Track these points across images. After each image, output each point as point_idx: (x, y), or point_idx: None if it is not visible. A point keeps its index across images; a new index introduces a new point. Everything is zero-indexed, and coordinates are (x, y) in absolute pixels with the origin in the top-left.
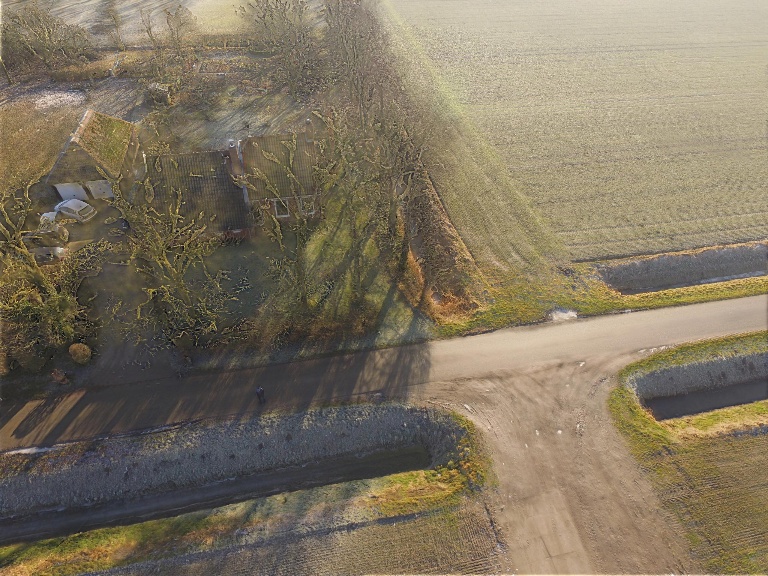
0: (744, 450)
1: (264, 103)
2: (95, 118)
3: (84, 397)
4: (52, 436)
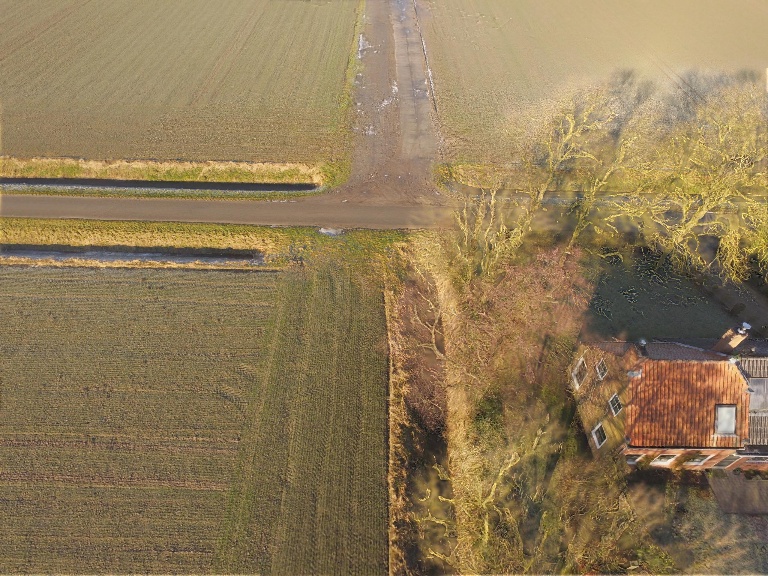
0: (287, 157)
1: None
2: None
3: None
4: None
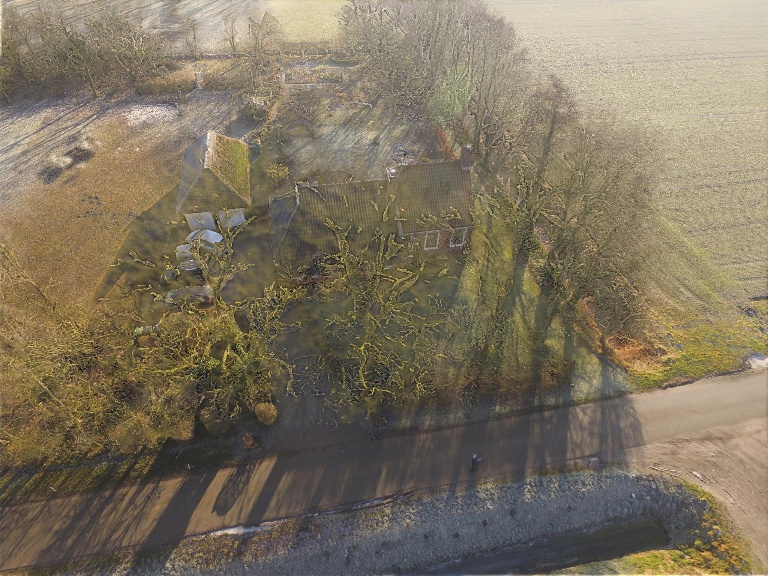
0: None
1: (364, 118)
2: (217, 140)
3: (278, 464)
4: (257, 512)
